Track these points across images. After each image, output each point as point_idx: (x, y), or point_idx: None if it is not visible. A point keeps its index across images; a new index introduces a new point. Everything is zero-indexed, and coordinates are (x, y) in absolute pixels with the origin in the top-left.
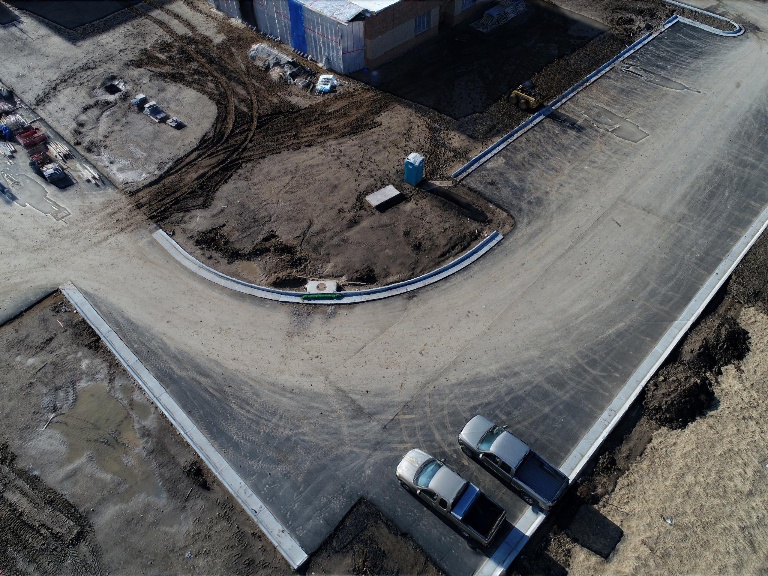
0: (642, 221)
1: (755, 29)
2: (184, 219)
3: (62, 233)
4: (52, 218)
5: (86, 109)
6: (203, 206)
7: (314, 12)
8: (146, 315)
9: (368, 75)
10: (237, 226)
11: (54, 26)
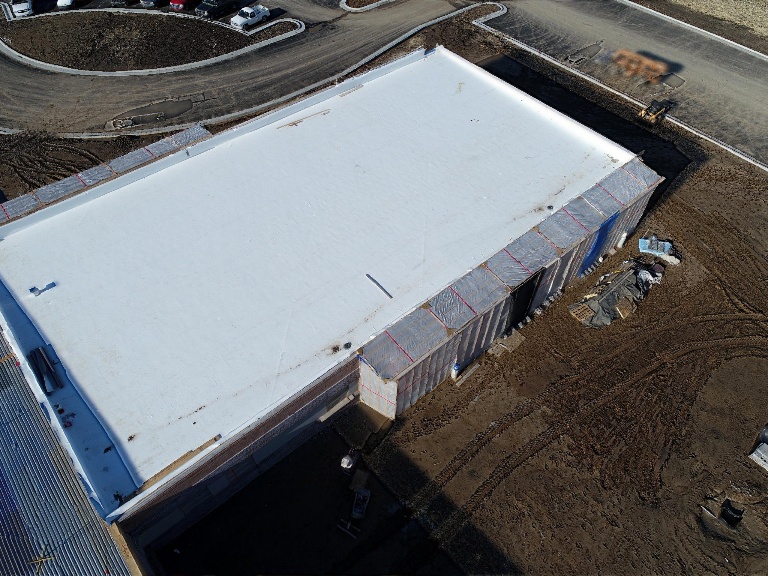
0: None
1: None
2: None
3: None
4: None
5: None
6: None
7: None
8: None
9: None
10: None
11: None
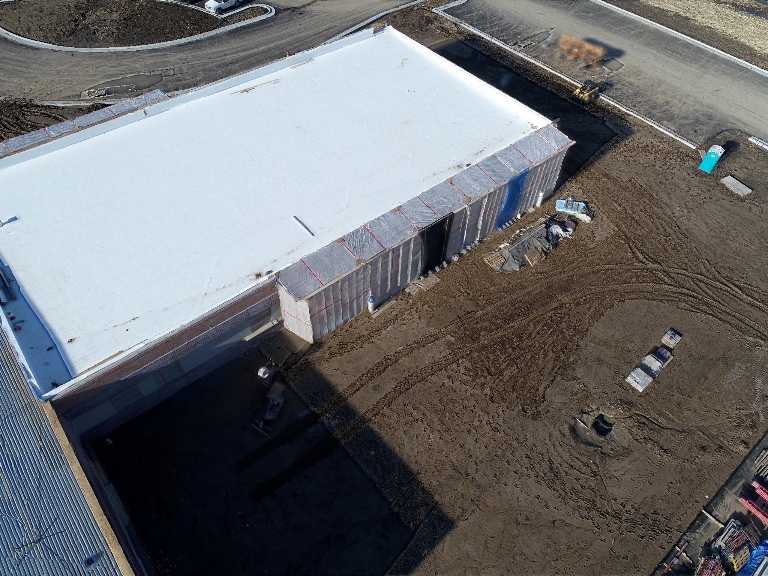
0: (712, 81)
1: None
2: None
3: None
4: None
5: (665, 450)
6: None
7: None
8: None
9: None
10: None
11: (396, 575)
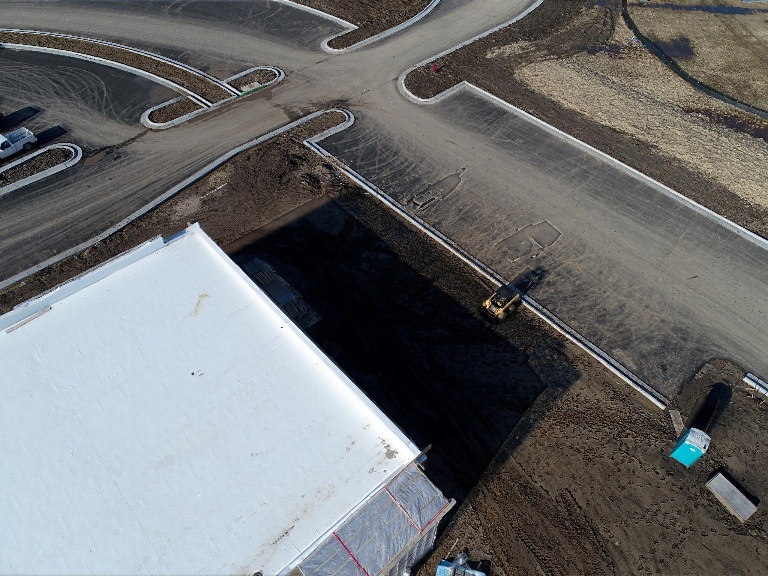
0: (685, 260)
1: (343, 102)
2: None
3: None
4: None
5: None
6: None
7: (389, 571)
8: None
9: None
10: None
11: None
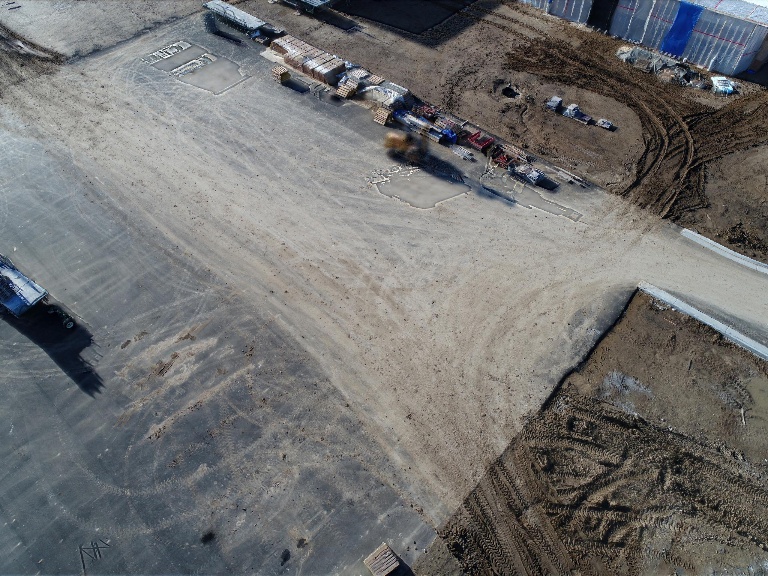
0: None
1: None
2: (696, 218)
3: (591, 234)
4: (568, 219)
5: (504, 112)
6: (704, 205)
7: (721, 15)
8: (746, 312)
9: (757, 76)
10: (754, 224)
11: (399, 31)
